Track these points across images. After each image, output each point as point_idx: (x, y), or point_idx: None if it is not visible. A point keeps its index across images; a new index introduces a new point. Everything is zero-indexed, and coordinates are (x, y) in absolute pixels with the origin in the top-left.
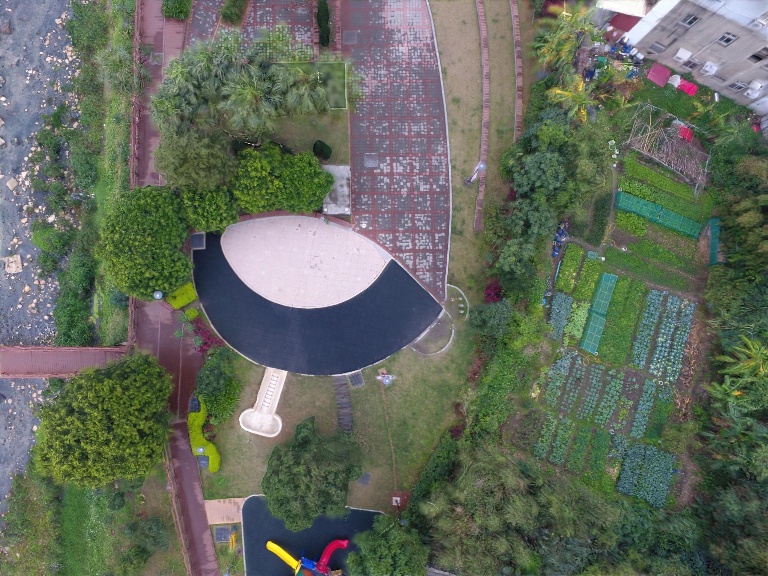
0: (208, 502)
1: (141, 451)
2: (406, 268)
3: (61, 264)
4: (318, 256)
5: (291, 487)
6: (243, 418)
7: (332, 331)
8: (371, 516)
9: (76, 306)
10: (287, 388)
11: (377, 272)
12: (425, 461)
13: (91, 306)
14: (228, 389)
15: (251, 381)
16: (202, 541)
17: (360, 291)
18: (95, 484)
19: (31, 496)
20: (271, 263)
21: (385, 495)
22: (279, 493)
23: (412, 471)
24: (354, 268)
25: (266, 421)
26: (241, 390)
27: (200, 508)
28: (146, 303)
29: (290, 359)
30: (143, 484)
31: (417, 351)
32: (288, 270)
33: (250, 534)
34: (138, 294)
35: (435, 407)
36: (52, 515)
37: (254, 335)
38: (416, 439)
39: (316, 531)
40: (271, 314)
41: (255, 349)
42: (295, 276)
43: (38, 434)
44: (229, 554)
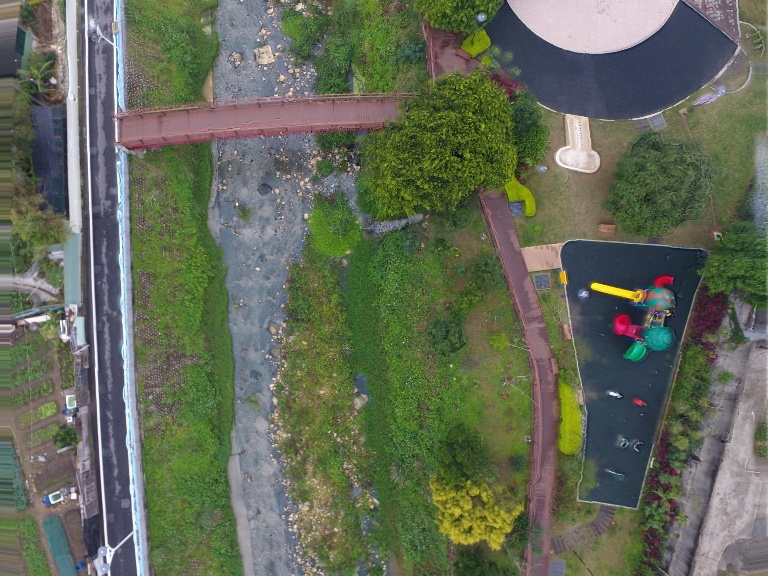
0: (526, 249)
1: (510, 150)
2: (696, 8)
3: (314, 52)
4: (605, 2)
5: (669, 176)
6: (560, 156)
7: (628, 75)
8: (694, 253)
9: (339, 88)
10: (591, 132)
11: (667, 14)
12: (743, 195)
13: (350, 91)
14: (539, 130)
15: (554, 127)
16: (523, 289)
17: (652, 34)
18: (462, 190)
19: (312, 283)
20: (558, 11)
21: (705, 232)
22: (650, 189)
23: (730, 206)
24: (643, 11)
25: (582, 159)
26: (549, 133)
27: (517, 256)
28: (438, 55)
29: (589, 105)
30: (455, 237)
31: (716, 90)
32: (576, 17)
33: (571, 279)
34: (466, 13)
35: (746, 141)
36: (338, 298)
37: (549, 83)
38: (731, 174)
39: (639, 272)
40: (564, 61)
41: (552, 97)
42: (584, 23)
43: (311, 221)
44: (552, 301)
